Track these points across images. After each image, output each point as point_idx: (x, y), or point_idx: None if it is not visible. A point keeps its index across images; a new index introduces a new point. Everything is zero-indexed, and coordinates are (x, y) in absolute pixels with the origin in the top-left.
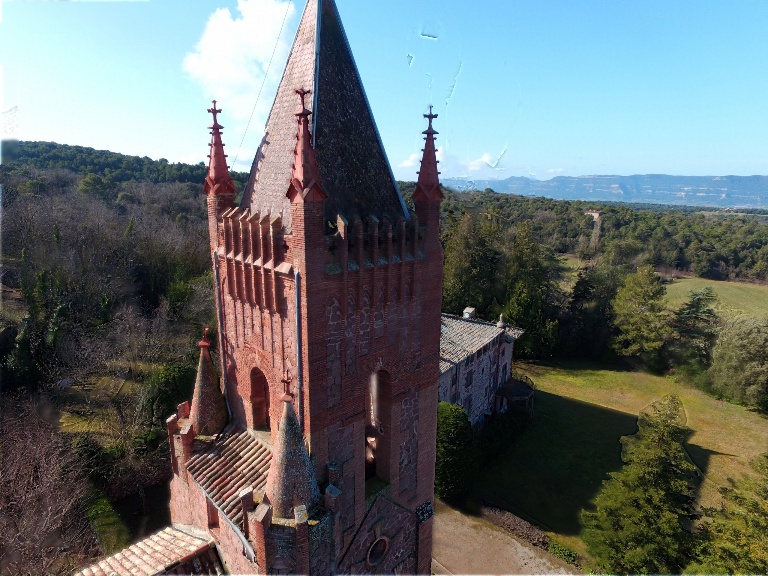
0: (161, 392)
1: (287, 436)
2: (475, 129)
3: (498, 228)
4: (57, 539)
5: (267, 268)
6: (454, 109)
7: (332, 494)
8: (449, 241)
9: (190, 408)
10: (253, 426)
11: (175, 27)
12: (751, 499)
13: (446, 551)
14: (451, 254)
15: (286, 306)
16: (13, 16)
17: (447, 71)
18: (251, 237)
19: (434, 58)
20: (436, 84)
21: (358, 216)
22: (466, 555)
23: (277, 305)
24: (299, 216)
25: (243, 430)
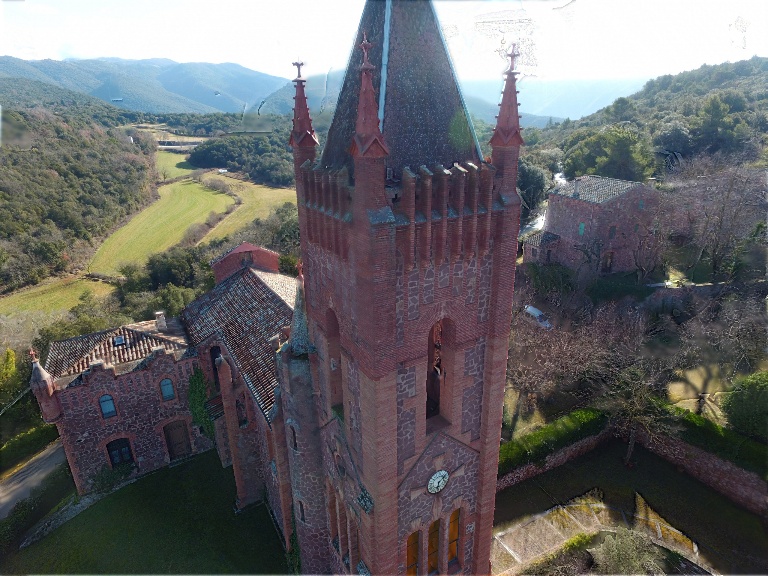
0: (728, 387)
1: None
2: None
3: None
4: (557, 410)
5: None
6: None
7: (282, 347)
8: None
9: (763, 434)
10: None
11: None
12: None
13: None
14: None
15: None
16: (523, 1)
17: None
18: None
19: None
20: None
21: (342, 165)
22: None
23: None
24: None
25: None
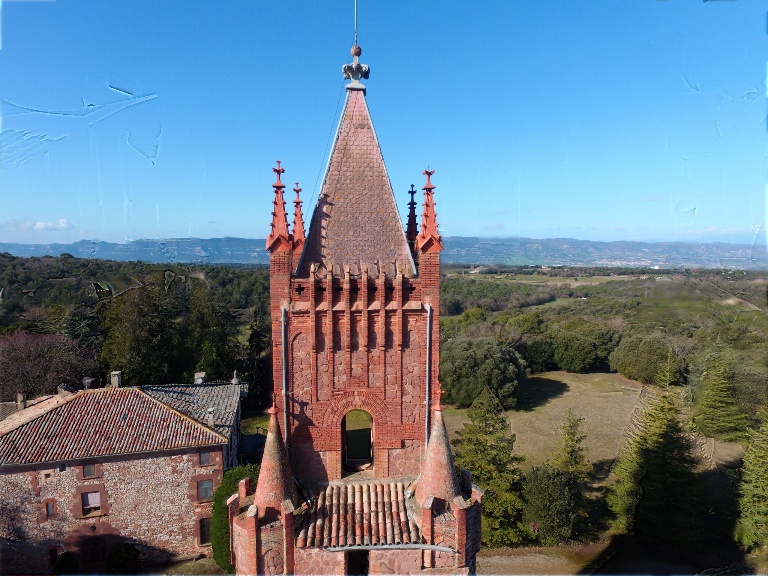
0: None
1: (446, 438)
2: (163, 190)
3: (194, 290)
4: None
5: (390, 309)
6: (134, 168)
7: None
8: (105, 312)
9: None
10: (341, 475)
11: (45, 44)
12: (474, 437)
13: None
14: (119, 326)
15: (408, 338)
16: None
17: (146, 130)
18: (367, 285)
19: (128, 114)
20: (135, 141)
21: None
22: None
23: (402, 339)
24: (434, 262)
25: (324, 487)
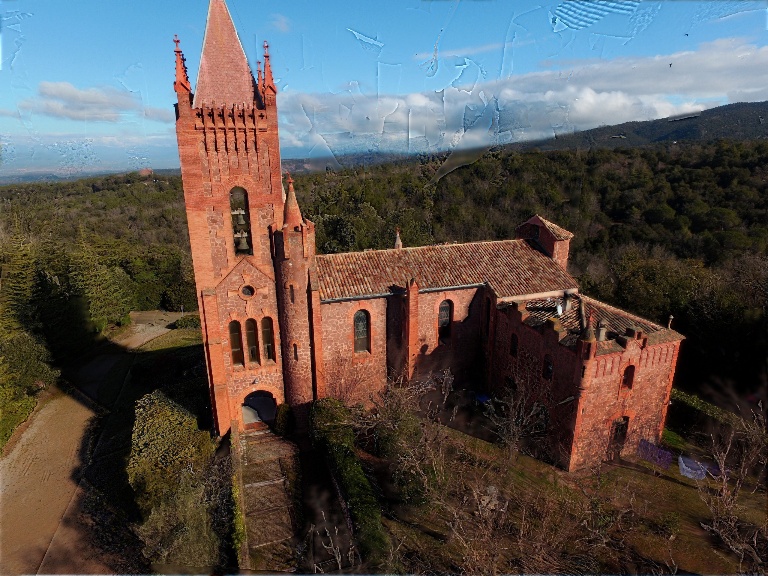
0: None
1: None
2: None
3: None
4: None
5: None
6: None
7: None
8: None
9: None
10: None
11: None
12: None
13: (15, 572)
14: None
15: None
16: None
17: None
18: None
19: None
20: None
21: None
22: (6, 561)
23: None
24: None
25: None
